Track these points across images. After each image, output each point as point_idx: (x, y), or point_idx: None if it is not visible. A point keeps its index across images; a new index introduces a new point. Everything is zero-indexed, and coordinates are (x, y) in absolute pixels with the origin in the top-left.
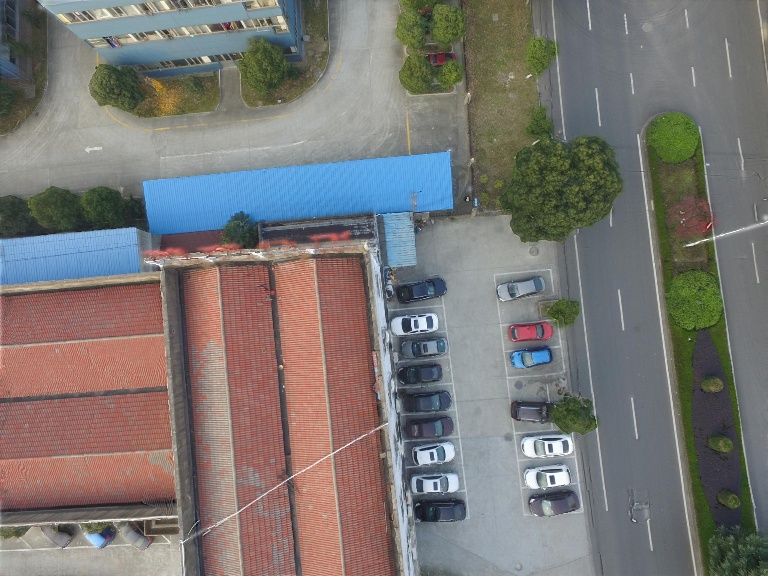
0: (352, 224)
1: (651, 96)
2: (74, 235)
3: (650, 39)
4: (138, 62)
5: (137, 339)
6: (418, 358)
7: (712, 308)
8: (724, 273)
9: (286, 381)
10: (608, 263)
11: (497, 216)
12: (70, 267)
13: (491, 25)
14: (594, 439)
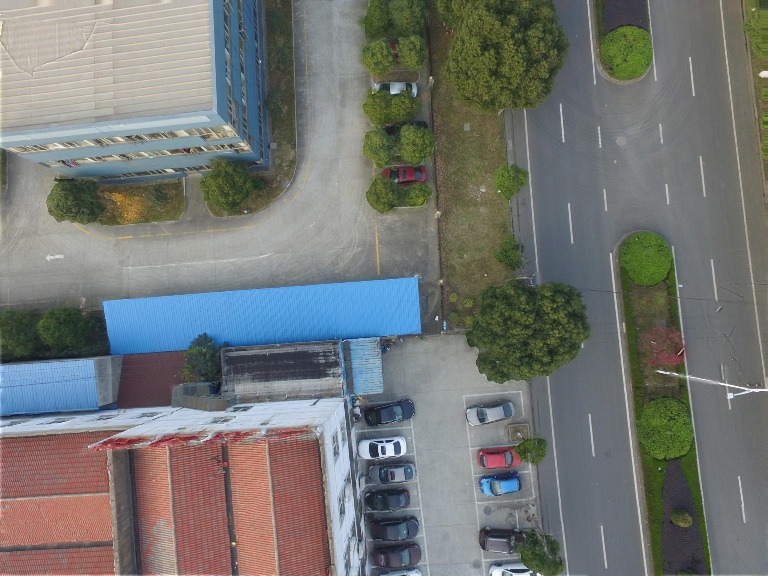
0: (317, 351)
1: (624, 213)
2: (29, 366)
3: (624, 153)
4: (98, 174)
5: (89, 497)
6: (386, 483)
7: (682, 439)
8: (695, 400)
9: (239, 559)
10: (579, 386)
11: None
12: (26, 399)
13: (462, 135)
14: (563, 567)
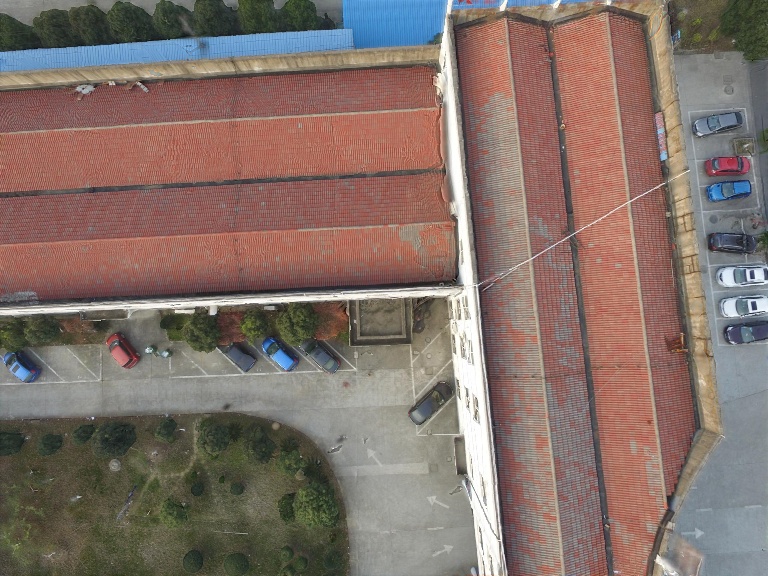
0: None
1: None
2: (286, 35)
3: None
4: None
5: (388, 114)
6: None
7: None
8: None
9: (568, 140)
10: None
11: (692, 55)
12: None
13: None
14: None
